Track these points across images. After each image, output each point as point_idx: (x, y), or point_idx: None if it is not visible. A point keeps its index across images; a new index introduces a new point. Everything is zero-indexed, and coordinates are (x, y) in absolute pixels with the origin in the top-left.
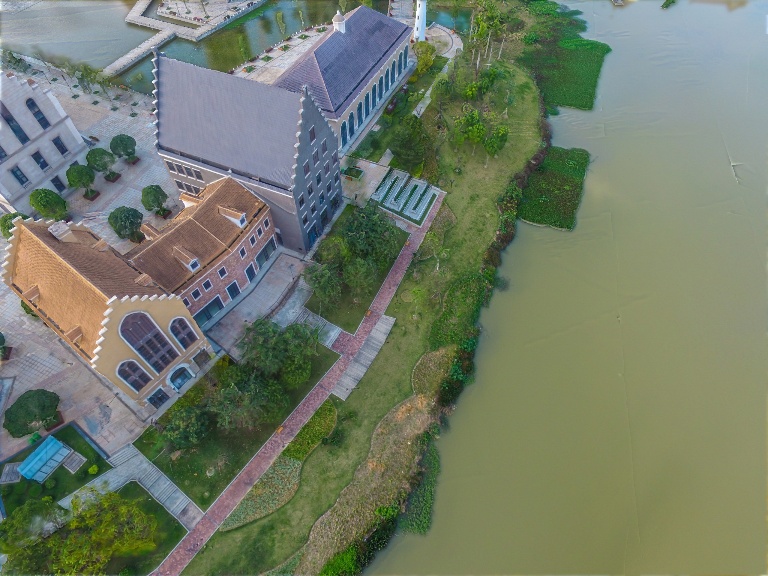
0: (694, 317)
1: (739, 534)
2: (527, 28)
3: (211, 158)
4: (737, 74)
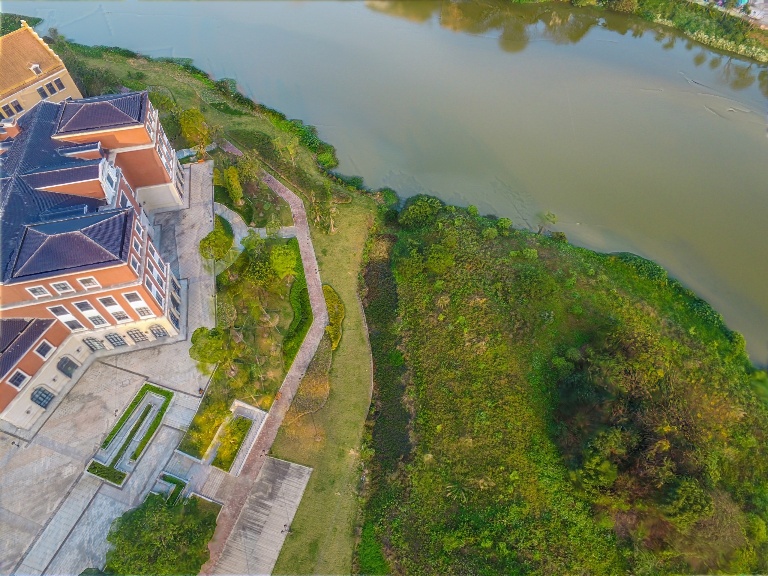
0: None
1: (211, 0)
2: None
3: None
4: None
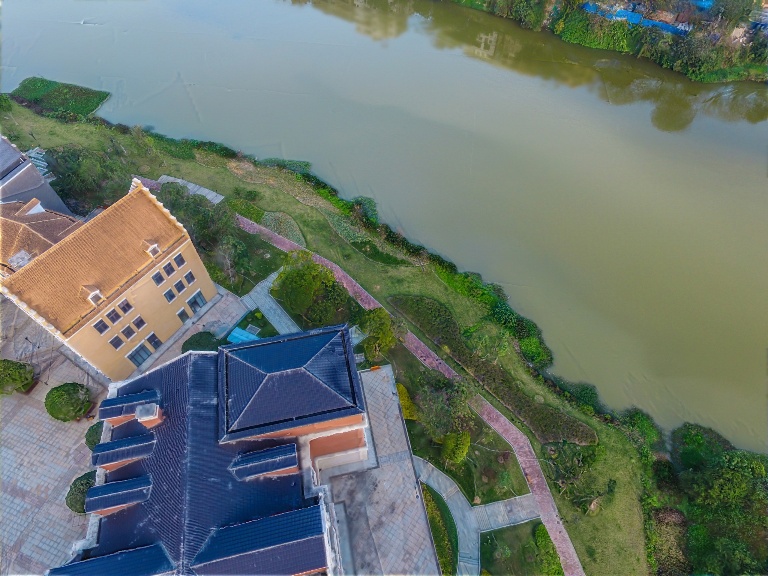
0: (199, 60)
1: (314, 69)
2: None
3: None
4: None
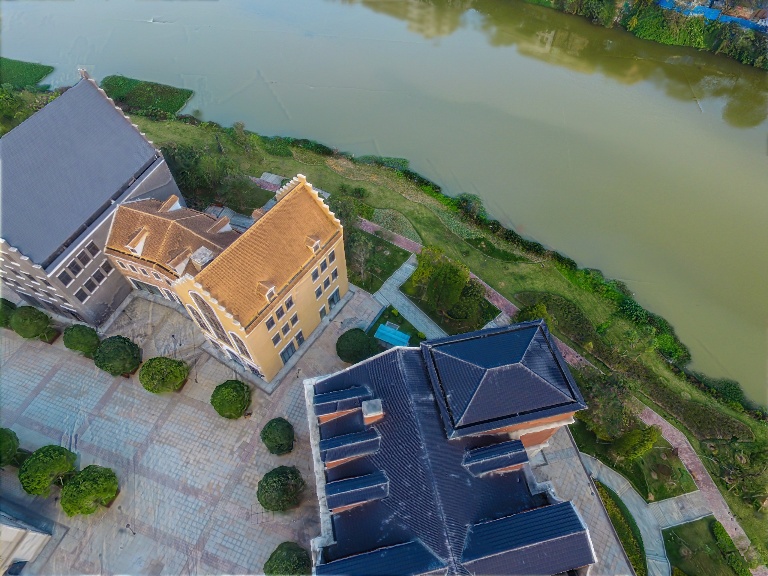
0: (275, 58)
1: (393, 66)
2: None
3: (91, 211)
4: None
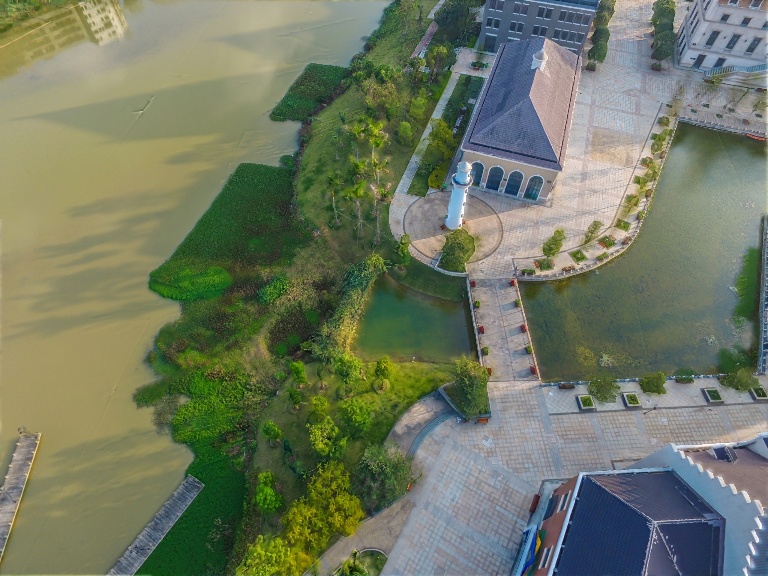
0: (256, 30)
1: None
2: (270, 319)
3: None
4: (5, 229)
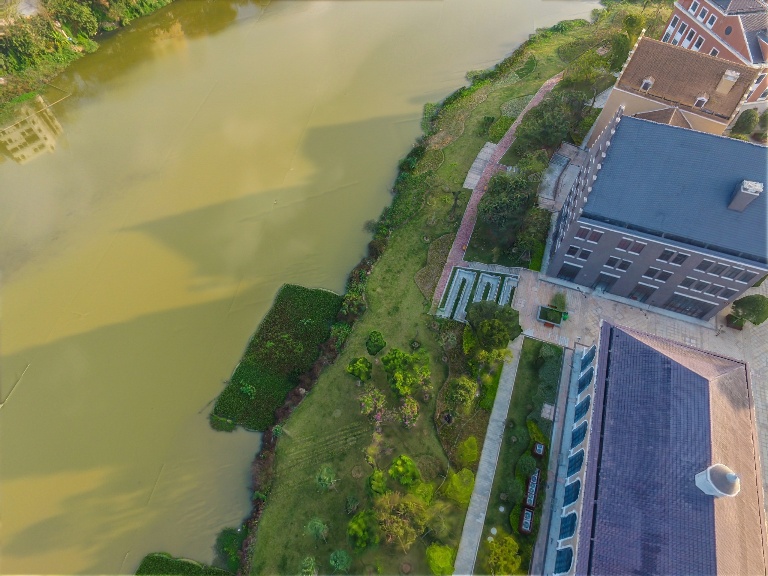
0: (209, 207)
1: (261, 106)
2: None
3: None
4: None
